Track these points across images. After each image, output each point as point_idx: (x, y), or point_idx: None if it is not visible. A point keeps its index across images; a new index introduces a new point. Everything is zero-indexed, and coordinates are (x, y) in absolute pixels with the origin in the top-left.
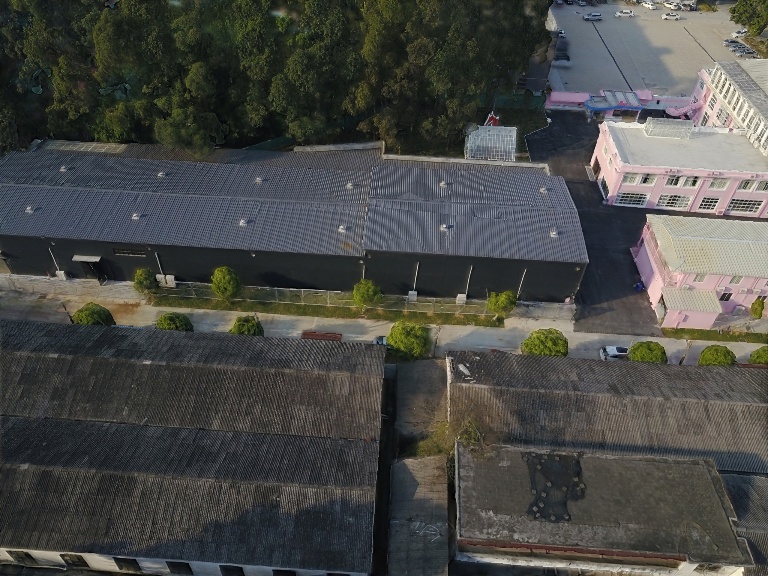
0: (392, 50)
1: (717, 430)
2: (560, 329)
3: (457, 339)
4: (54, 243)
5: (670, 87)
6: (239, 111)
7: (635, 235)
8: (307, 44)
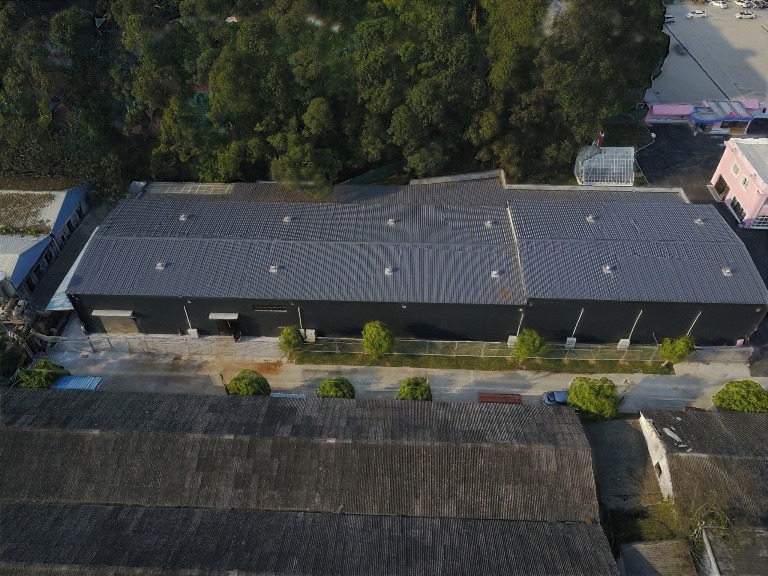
0: (517, 75)
1: None
2: (736, 374)
3: (629, 390)
4: (190, 301)
5: (767, 92)
6: (349, 144)
7: None
8: (430, 73)
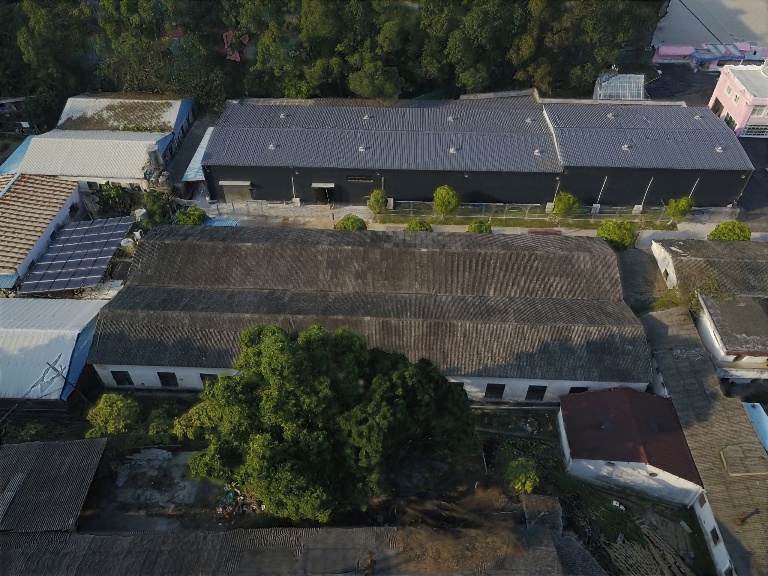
0: (550, 6)
1: None
2: None
3: (642, 240)
4: (298, 172)
5: (758, 41)
6: (409, 67)
7: (767, 159)
8: (480, 2)
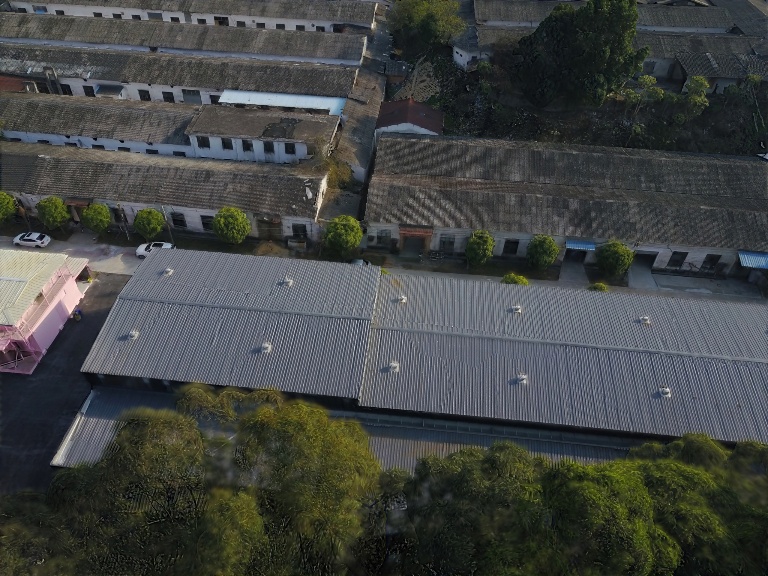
0: None
1: (157, 160)
2: None
3: None
4: None
5: None
6: None
7: None
8: None
